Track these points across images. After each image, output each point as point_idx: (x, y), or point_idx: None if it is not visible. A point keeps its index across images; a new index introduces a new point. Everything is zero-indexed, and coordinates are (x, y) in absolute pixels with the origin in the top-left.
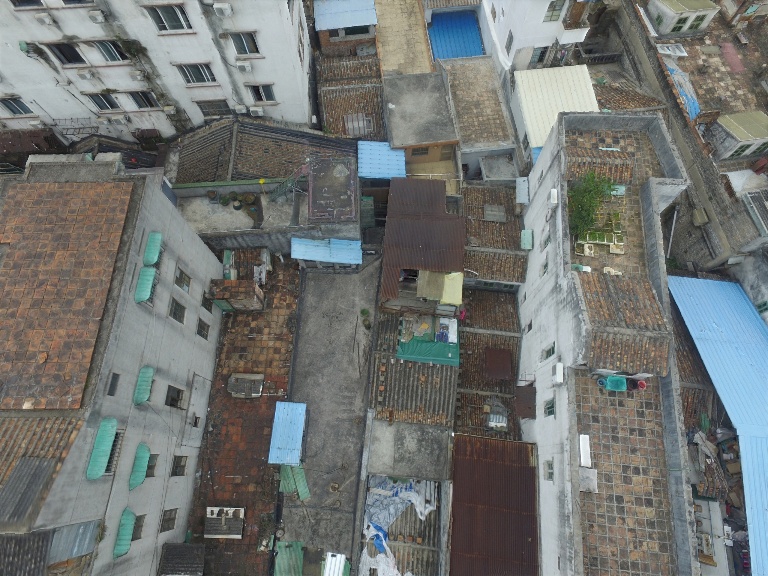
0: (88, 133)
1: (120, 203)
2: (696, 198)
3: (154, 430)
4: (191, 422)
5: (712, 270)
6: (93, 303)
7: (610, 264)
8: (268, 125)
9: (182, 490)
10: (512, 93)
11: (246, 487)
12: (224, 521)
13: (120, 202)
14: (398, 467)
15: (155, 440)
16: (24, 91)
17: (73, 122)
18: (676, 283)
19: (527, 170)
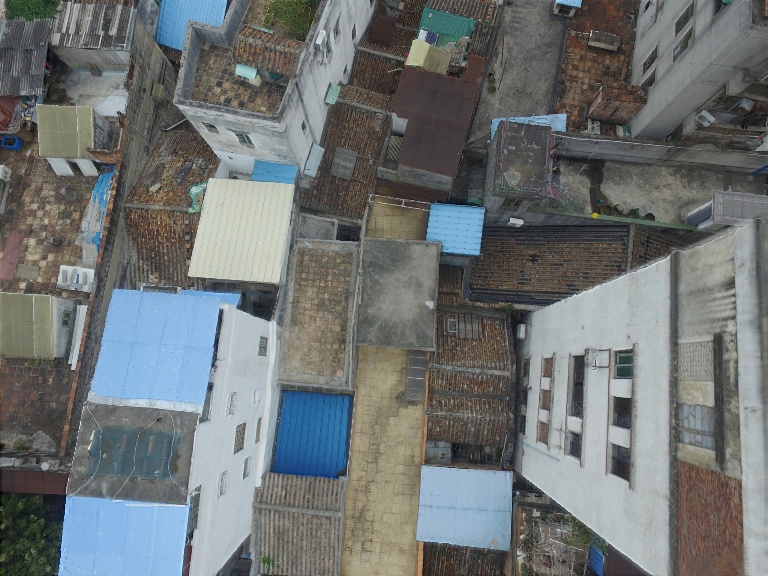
0: None
1: None
2: None
3: None
4: None
5: None
6: None
7: None
8: None
9: None
10: (279, 294)
11: None
12: None
13: None
14: None
15: None
16: None
17: None
18: None
19: None
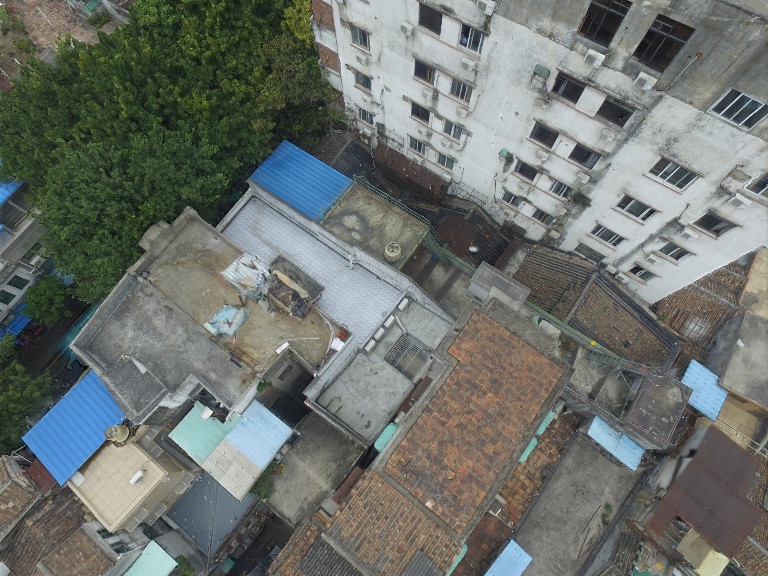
0: (473, 200)
1: (548, 382)
2: None
3: None
4: None
5: None
6: (499, 456)
7: None
8: (619, 288)
9: None
10: None
11: None
12: None
13: (548, 382)
14: None
15: None
16: (464, 162)
17: (473, 192)
18: None
19: None
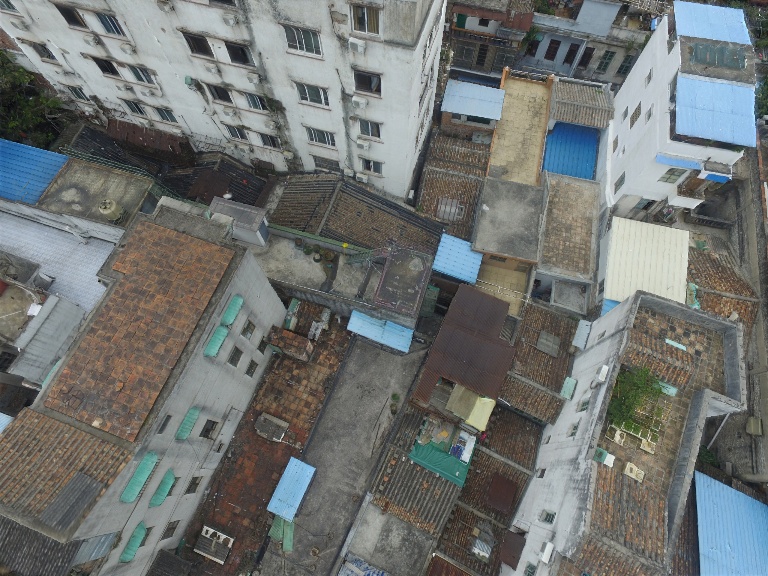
0: (216, 149)
1: (219, 267)
2: (757, 405)
3: (183, 458)
4: (215, 449)
5: (749, 482)
6: (171, 352)
7: (636, 459)
8: (368, 190)
9: (189, 505)
10: (606, 231)
11: (242, 520)
12: (214, 544)
13: (219, 266)
14: (376, 556)
15: (182, 466)
16: (177, 107)
17: (207, 139)
18: (705, 484)
19: (594, 313)
